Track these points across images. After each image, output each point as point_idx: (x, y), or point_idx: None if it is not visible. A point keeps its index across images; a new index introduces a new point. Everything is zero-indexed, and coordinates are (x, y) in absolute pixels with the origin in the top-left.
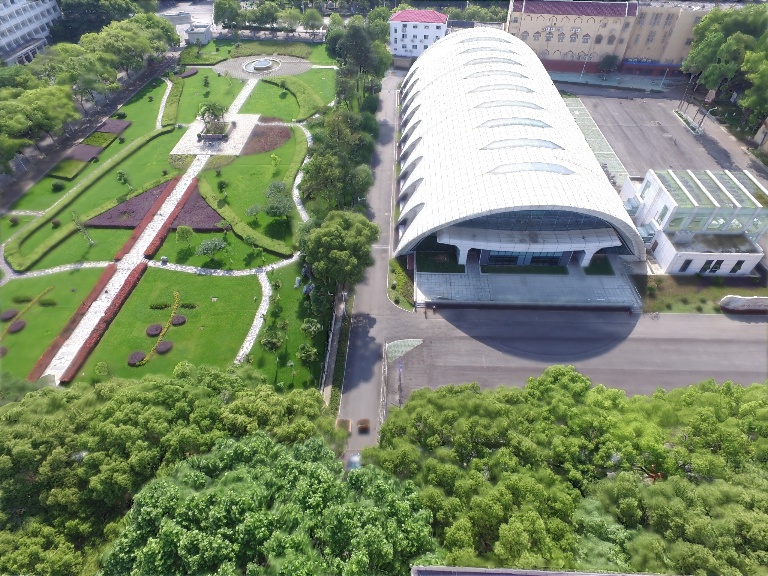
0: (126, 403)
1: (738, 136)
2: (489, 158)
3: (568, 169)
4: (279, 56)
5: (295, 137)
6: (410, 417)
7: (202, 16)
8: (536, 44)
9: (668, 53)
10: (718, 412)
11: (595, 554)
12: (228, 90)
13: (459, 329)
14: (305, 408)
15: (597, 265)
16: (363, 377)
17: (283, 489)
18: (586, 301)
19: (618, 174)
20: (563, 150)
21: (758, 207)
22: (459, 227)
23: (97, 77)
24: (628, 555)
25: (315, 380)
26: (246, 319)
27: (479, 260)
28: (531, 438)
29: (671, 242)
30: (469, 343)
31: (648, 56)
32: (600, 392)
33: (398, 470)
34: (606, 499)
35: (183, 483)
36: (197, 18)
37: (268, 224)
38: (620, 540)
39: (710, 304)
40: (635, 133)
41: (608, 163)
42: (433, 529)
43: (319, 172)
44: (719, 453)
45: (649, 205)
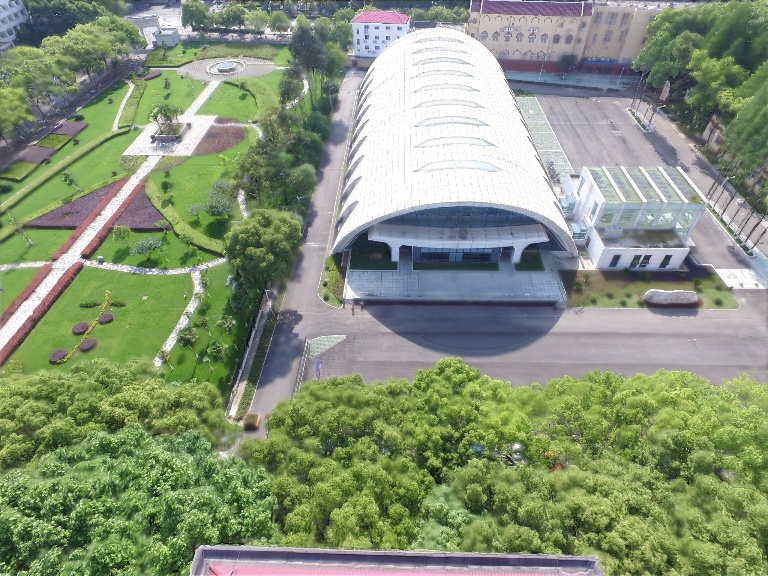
0: (7, 397)
1: (687, 133)
2: (420, 156)
3: (495, 166)
4: (244, 58)
5: (248, 138)
6: (288, 408)
7: (173, 19)
8: (496, 44)
9: (625, 52)
10: (586, 401)
11: (428, 538)
12: (189, 92)
13: (384, 325)
14: (193, 401)
15: (528, 261)
16: (280, 372)
17: (139, 478)
18: (512, 296)
19: (563, 172)
20: (495, 148)
21: (684, 202)
22: (390, 224)
23: (53, 80)
24: (461, 538)
25: (231, 376)
26: (173, 317)
27: (411, 257)
28: (401, 428)
29: (601, 238)
30: (392, 338)
31: (606, 55)
32: (484, 383)
33: (266, 460)
34: (459, 485)
35: (41, 473)
36: (168, 21)
37: (209, 223)
38: (457, 524)
39: (635, 298)
40: (586, 131)
41: (555, 161)
42: (276, 515)
43: (244, 171)
44: (580, 440)
45: (583, 202)
